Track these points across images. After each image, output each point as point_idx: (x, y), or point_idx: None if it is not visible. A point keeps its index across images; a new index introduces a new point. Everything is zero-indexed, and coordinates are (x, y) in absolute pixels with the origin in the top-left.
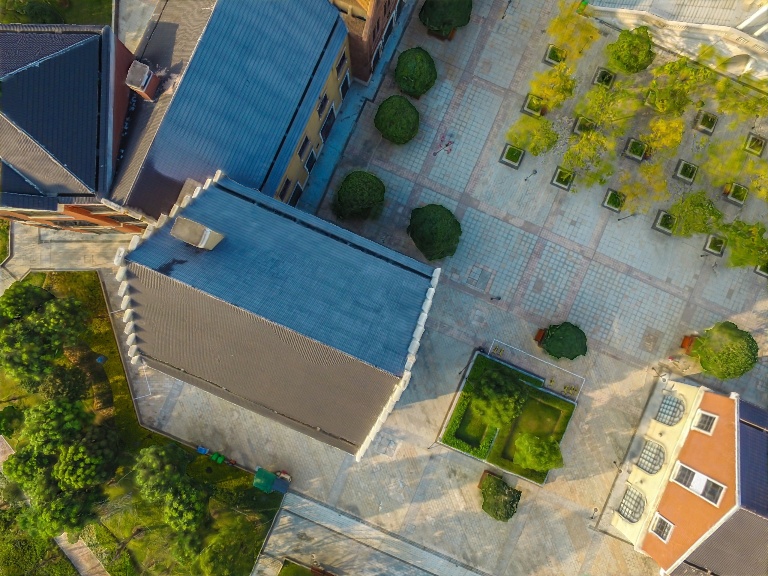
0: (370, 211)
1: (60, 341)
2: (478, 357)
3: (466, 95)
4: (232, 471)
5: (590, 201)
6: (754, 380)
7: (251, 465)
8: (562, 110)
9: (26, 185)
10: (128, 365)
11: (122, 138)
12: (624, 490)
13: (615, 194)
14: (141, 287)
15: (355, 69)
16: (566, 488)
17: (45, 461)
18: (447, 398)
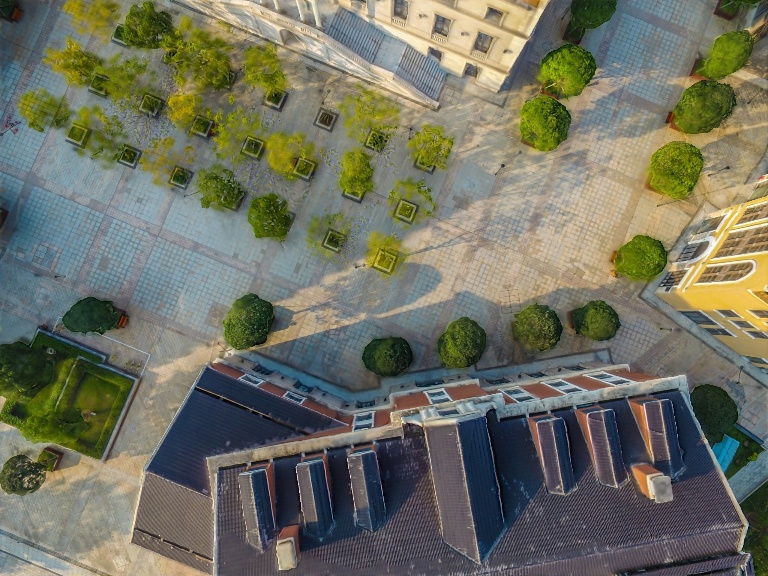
0: None
1: None
2: (38, 335)
3: (34, 75)
4: None
5: (157, 178)
6: (321, 353)
7: None
8: (131, 89)
9: None
10: None
11: None
12: None
13: (180, 171)
14: None
15: None
16: (130, 463)
17: None
18: None
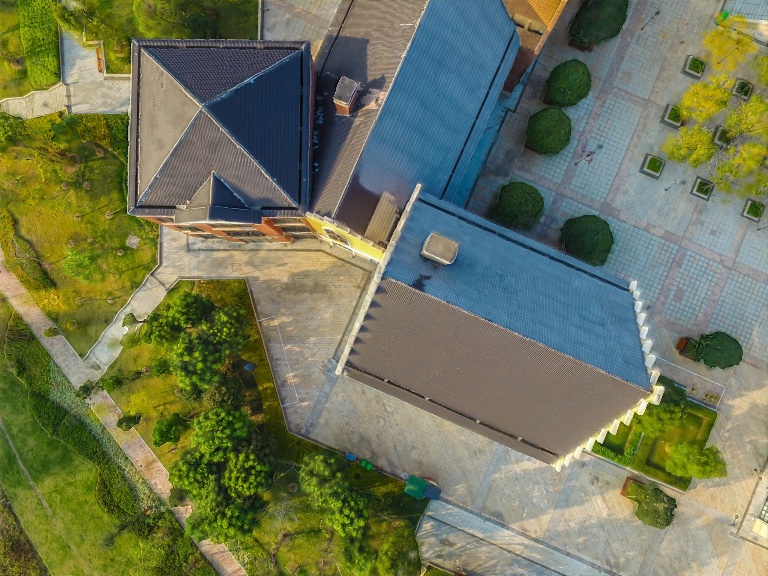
0: (513, 220)
1: (230, 350)
2: None
3: (606, 105)
4: (380, 477)
5: (729, 211)
6: None
7: (397, 471)
8: (701, 120)
9: (234, 199)
10: (276, 372)
11: (314, 151)
12: (765, 497)
13: (755, 204)
14: (385, 302)
15: (505, 80)
16: (707, 495)
17: (213, 468)
18: None
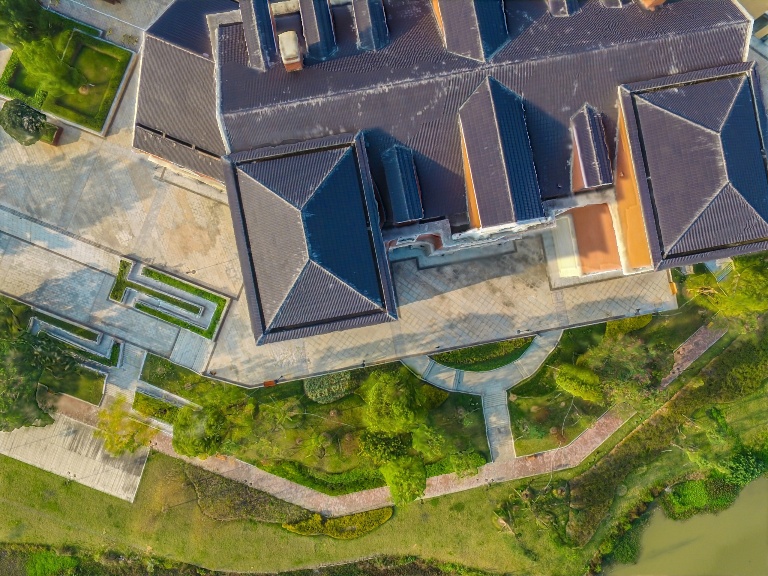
0: None
1: None
2: None
3: None
4: None
5: None
6: None
7: None
8: None
9: None
10: None
11: None
12: None
13: None
14: None
15: None
16: (130, 140)
17: None
18: (7, 53)
